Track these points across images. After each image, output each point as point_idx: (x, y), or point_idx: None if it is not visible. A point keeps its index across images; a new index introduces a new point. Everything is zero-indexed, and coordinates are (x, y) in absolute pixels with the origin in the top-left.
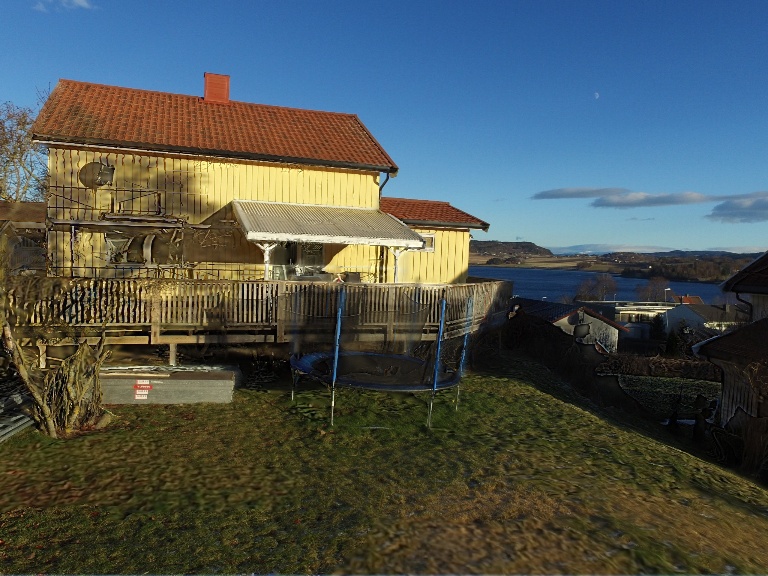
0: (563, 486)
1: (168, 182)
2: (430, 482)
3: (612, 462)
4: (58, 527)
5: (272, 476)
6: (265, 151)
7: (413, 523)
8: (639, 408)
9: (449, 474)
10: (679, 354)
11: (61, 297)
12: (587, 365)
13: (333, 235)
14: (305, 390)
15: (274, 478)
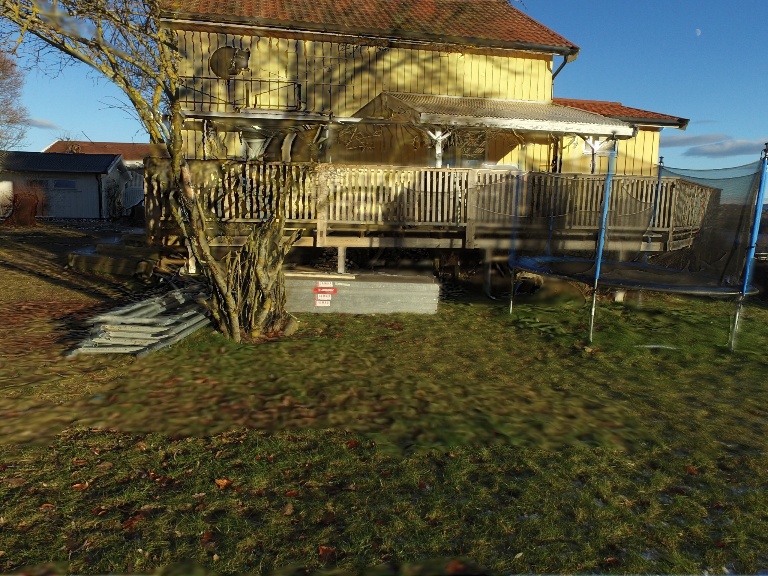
0: None
1: (309, 70)
2: None
3: None
4: (306, 462)
5: (573, 400)
6: (421, 29)
7: None
8: None
9: None
10: None
11: (211, 185)
12: None
13: (523, 119)
14: (516, 304)
15: (579, 403)
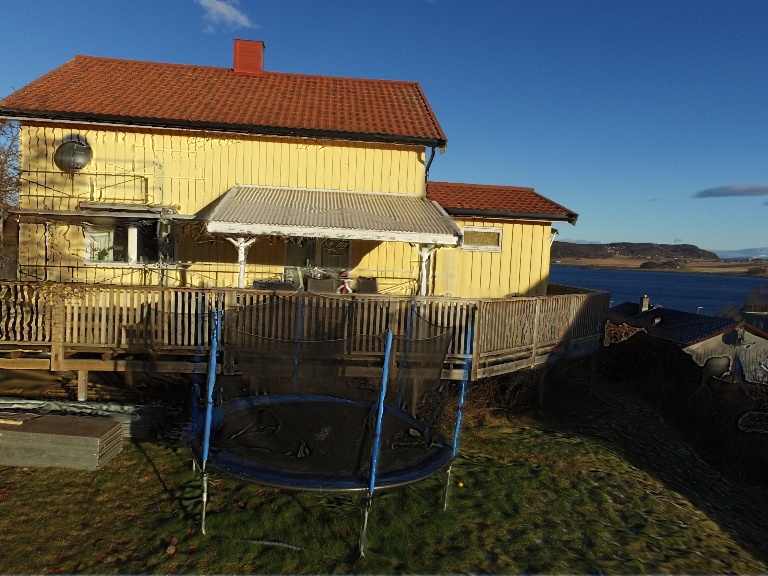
0: None
1: None
2: None
3: None
4: None
5: None
6: (273, 122)
7: None
8: None
9: None
10: None
11: None
12: (723, 416)
13: (327, 227)
14: None
15: None
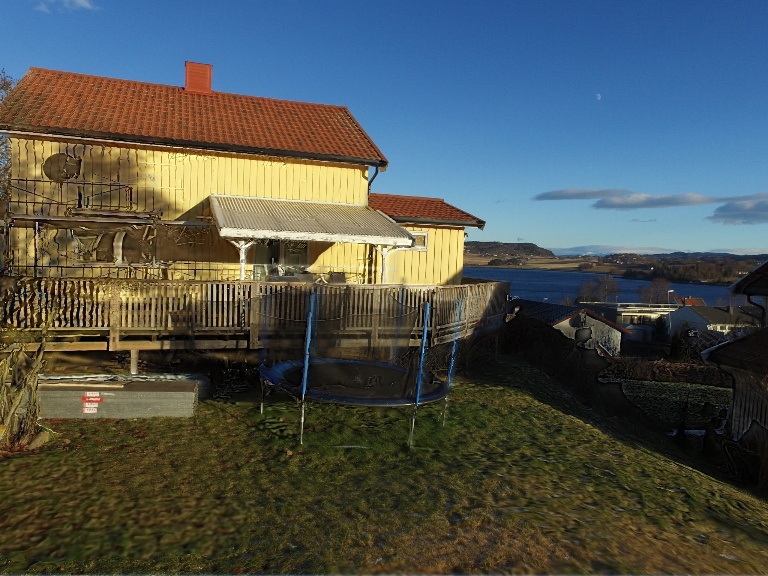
0: (560, 521)
1: (140, 175)
2: (405, 516)
3: (617, 487)
4: None
5: (221, 509)
6: (245, 143)
7: (379, 573)
8: (644, 417)
9: (428, 506)
10: (683, 357)
11: (8, 299)
12: (589, 371)
13: (314, 232)
14: (278, 402)
15: (222, 511)
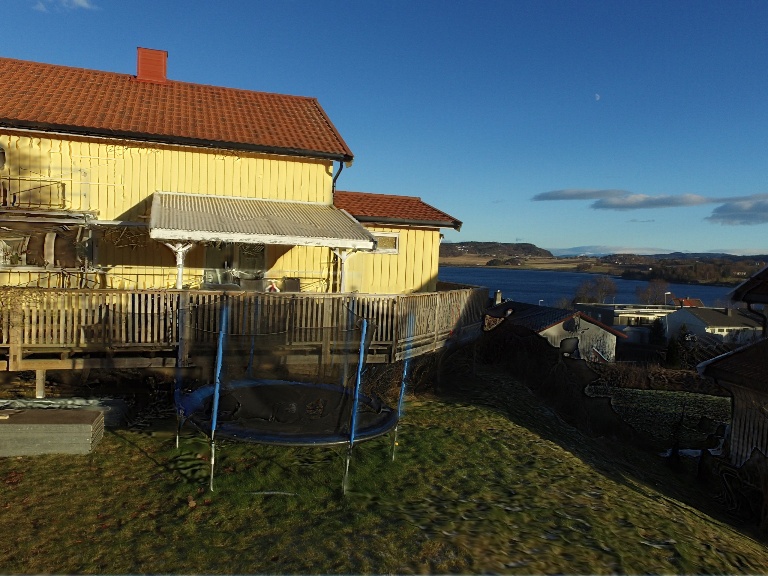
0: None
1: (74, 170)
2: None
3: (590, 547)
4: None
5: None
6: (193, 134)
7: None
8: (635, 436)
9: None
10: (680, 363)
11: None
12: (575, 385)
13: (261, 233)
14: None
15: None
